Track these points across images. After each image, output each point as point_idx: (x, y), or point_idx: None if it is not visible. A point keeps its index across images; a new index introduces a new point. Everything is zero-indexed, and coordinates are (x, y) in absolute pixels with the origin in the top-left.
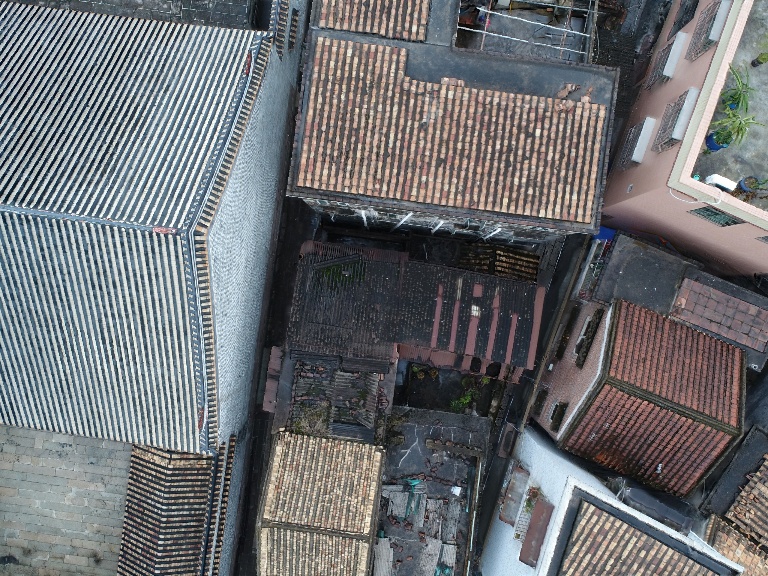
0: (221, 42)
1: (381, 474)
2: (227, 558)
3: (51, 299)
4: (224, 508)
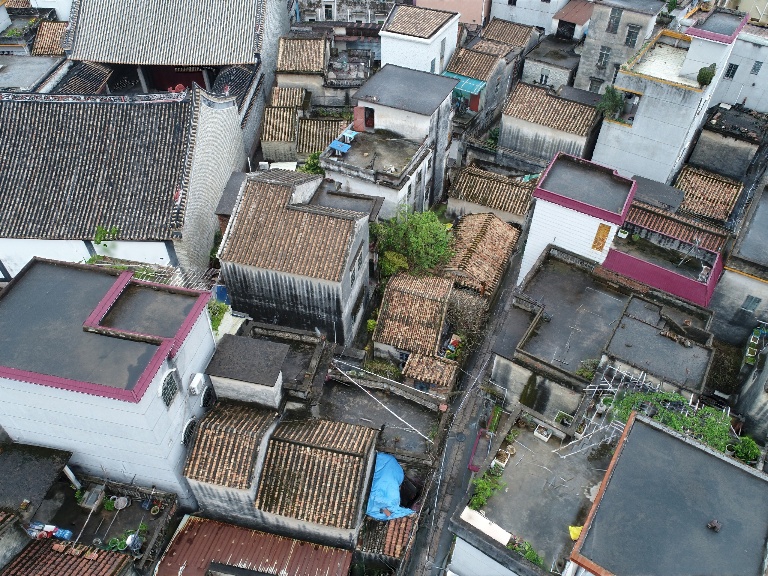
0: None
1: (329, 41)
2: (253, 130)
3: (206, 4)
4: (258, 89)
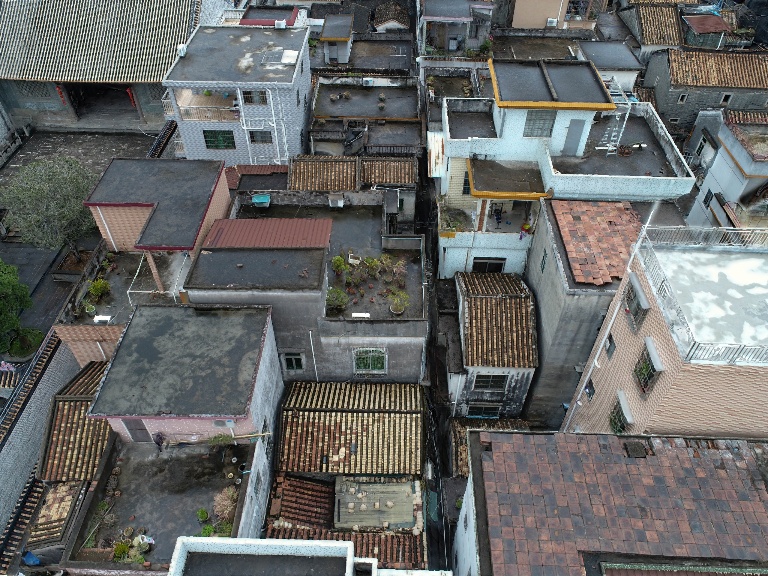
0: (3, 69)
1: None
2: None
3: None
4: None
